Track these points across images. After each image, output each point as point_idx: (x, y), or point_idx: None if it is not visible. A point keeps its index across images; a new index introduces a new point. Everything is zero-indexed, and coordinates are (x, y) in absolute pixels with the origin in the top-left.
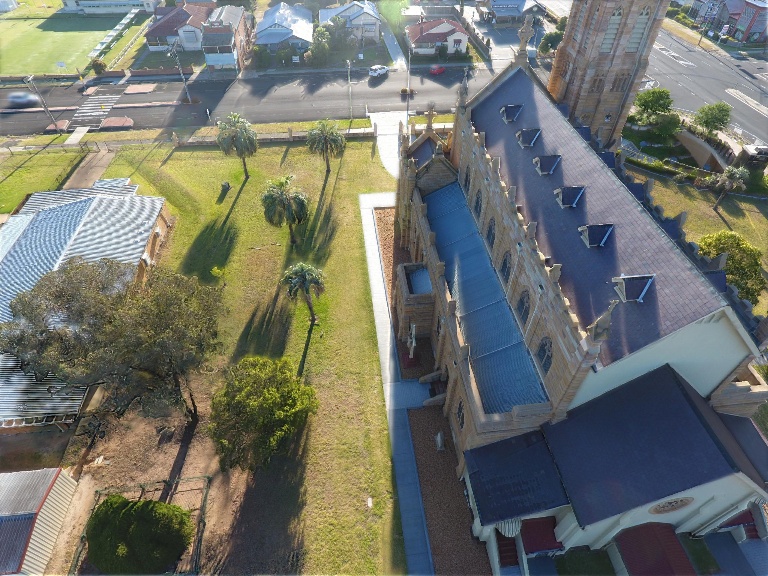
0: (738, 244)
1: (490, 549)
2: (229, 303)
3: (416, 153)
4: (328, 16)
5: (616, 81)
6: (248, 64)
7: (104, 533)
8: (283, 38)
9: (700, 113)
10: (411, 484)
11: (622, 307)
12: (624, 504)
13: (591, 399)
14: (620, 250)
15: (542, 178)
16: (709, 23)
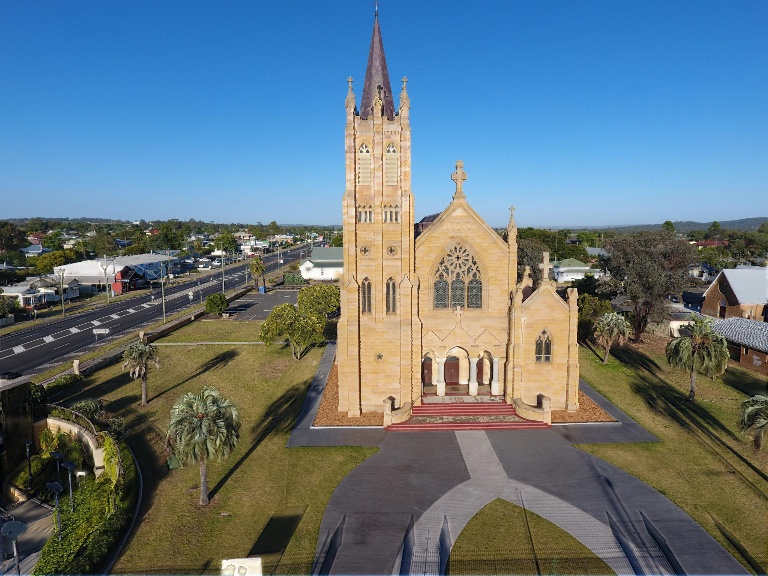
0: None
1: None
2: None
3: None
4: None
5: None
6: None
7: None
8: None
9: None
10: None
11: None
12: None
13: None
14: None
15: None
16: None
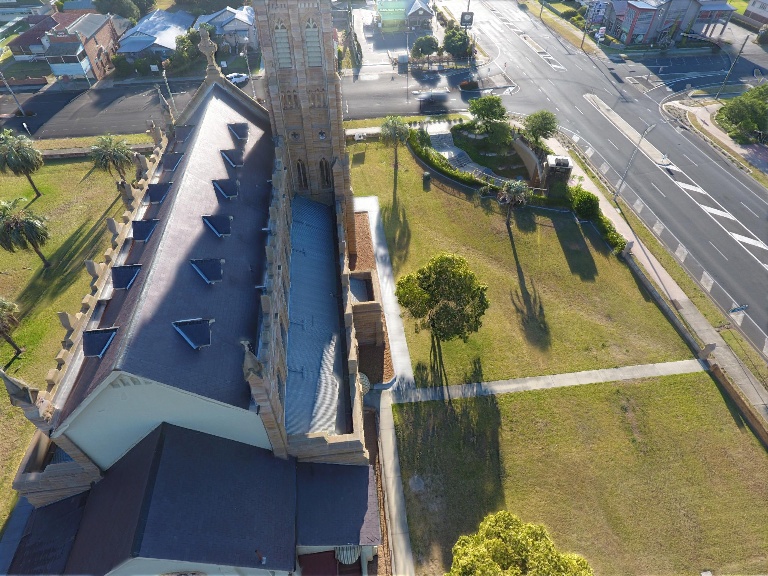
0: (454, 268)
1: None
2: None
3: None
4: (201, 22)
5: (314, 97)
6: (109, 73)
7: None
8: (146, 46)
9: (527, 121)
10: (15, 541)
11: None
12: None
13: (120, 458)
14: (127, 296)
15: None
16: (598, 25)
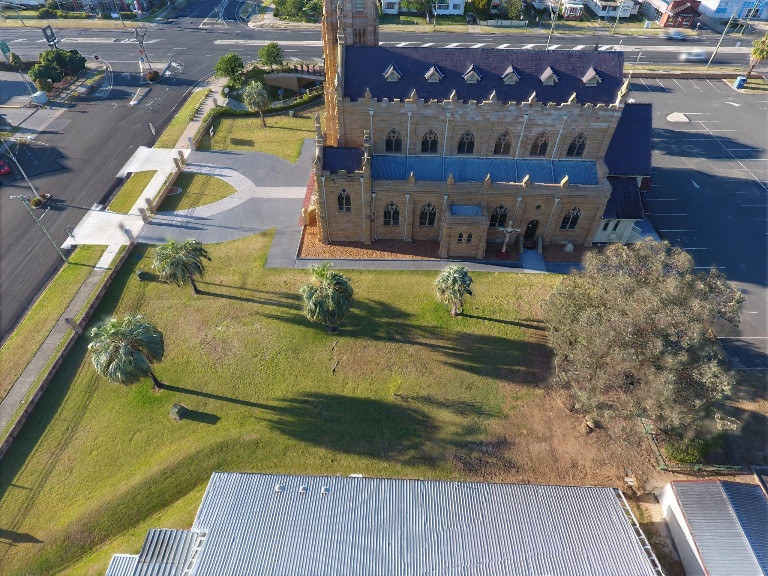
0: None
1: (633, 237)
2: (426, 388)
3: (328, 165)
4: None
5: None
6: None
7: (711, 421)
8: None
9: (265, 57)
10: None
11: (598, 88)
12: (649, 152)
13: None
14: (568, 72)
15: (480, 83)
16: (99, 8)
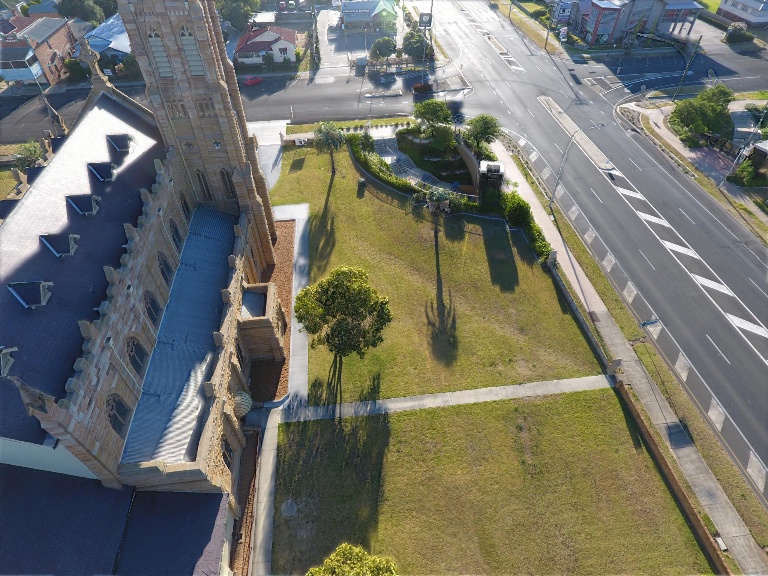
0: (350, 281)
1: None
2: None
3: None
4: None
5: (202, 106)
6: (64, 78)
7: None
8: (101, 50)
9: (469, 125)
10: None
11: None
12: None
13: None
14: None
15: None
16: None
